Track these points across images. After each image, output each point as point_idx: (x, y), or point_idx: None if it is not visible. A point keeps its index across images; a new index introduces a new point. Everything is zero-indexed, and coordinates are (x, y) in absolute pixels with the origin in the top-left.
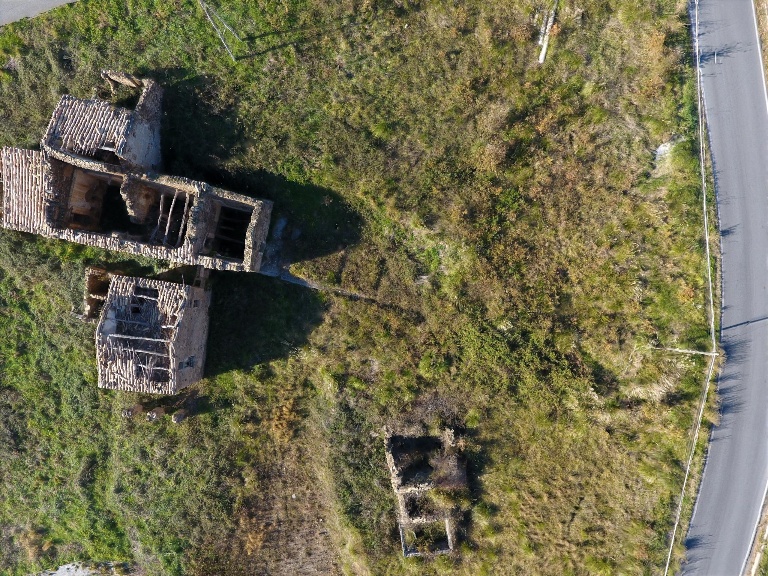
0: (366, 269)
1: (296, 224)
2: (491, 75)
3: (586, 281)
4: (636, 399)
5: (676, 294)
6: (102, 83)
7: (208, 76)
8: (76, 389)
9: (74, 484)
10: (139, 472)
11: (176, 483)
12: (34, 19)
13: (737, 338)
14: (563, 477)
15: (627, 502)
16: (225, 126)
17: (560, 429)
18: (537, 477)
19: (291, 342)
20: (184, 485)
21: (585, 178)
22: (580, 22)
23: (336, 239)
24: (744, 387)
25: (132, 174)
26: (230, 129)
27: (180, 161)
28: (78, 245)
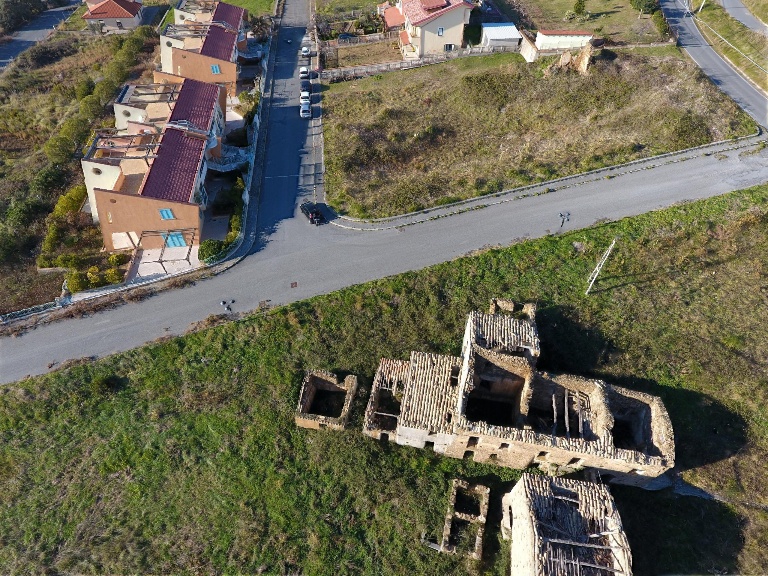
0: (765, 477)
1: None
2: None
3: None
4: None
5: None
6: None
7: (567, 305)
8: None
9: None
10: None
11: None
12: (418, 271)
13: None
14: None
15: None
16: (592, 339)
17: None
18: None
19: None
20: None
21: None
22: None
23: (719, 444)
24: None
25: (536, 372)
26: (598, 342)
27: (557, 367)
28: (433, 458)
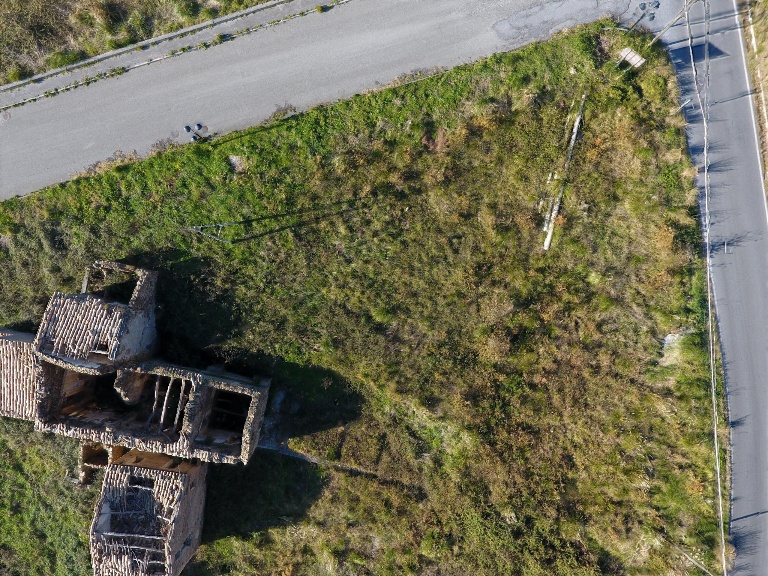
0: (366, 444)
1: (295, 398)
2: (494, 262)
3: (592, 467)
4: None
5: (684, 485)
6: None
7: (204, 259)
8: (71, 550)
9: None
10: None
11: None
12: (25, 198)
13: (747, 529)
14: None
15: None
16: (221, 310)
17: None
18: None
19: (290, 517)
20: None
21: (591, 363)
22: (586, 215)
23: (336, 414)
24: None
25: (126, 369)
26: (226, 313)
27: (175, 344)
28: None
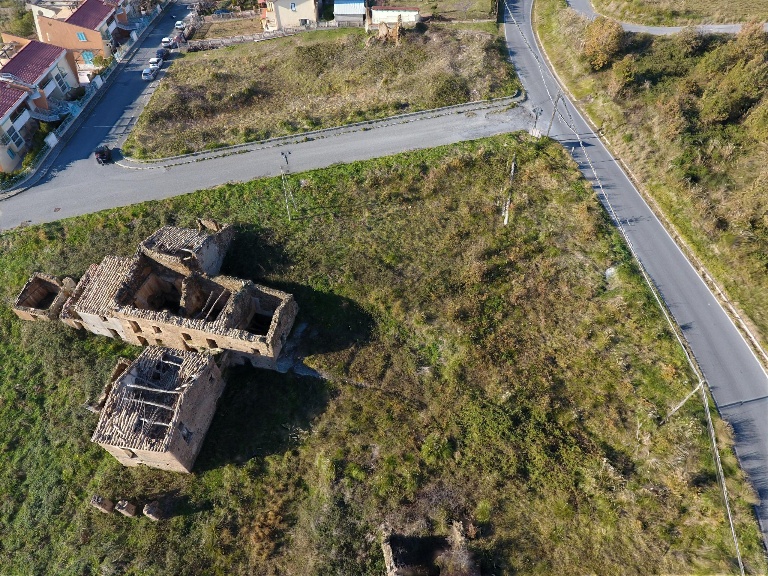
0: (373, 363)
1: (315, 327)
2: (471, 230)
3: (574, 367)
4: (656, 474)
5: (660, 375)
6: None
7: (269, 228)
8: (47, 488)
9: None
10: None
11: None
12: (161, 200)
13: (737, 417)
14: None
15: None
16: (274, 254)
17: (585, 523)
18: None
19: None
20: None
21: (554, 291)
22: (528, 202)
23: (348, 338)
24: None
25: (196, 272)
26: (277, 256)
27: (233, 274)
28: (120, 345)
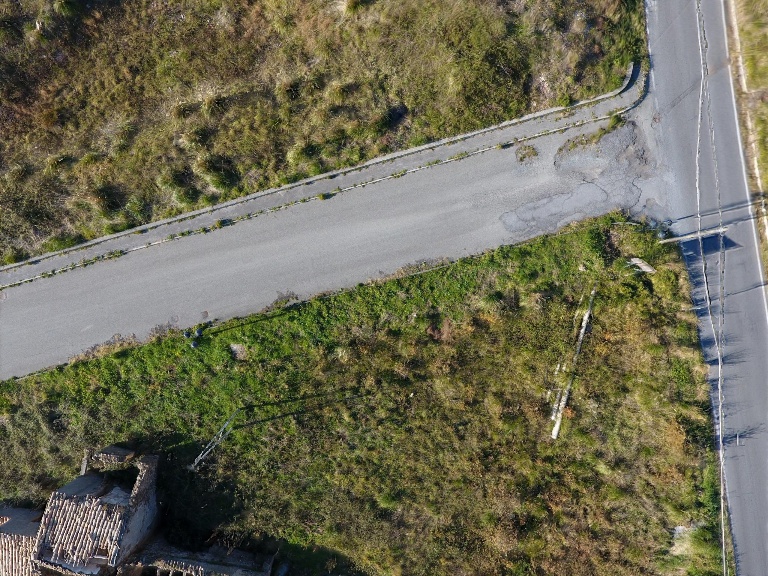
0: None
1: (298, 572)
2: (501, 451)
3: None
4: None
5: None
6: (94, 445)
7: (205, 444)
8: None
9: None
10: None
11: None
12: (22, 381)
13: None
14: None
15: None
16: (223, 495)
17: None
18: None
19: None
20: None
21: (600, 549)
22: None
23: None
24: None
25: (126, 565)
26: (228, 498)
27: (177, 528)
28: None
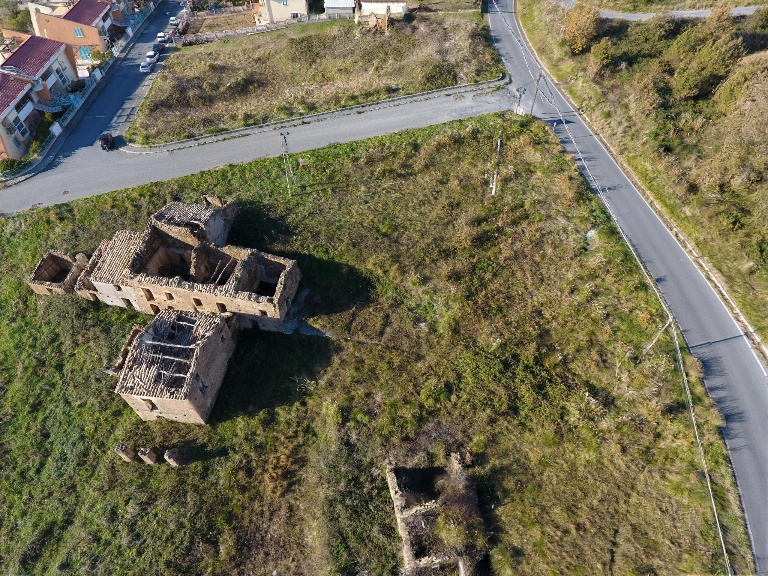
0: (373, 321)
1: (318, 291)
2: (461, 200)
3: (559, 318)
4: (633, 404)
5: (637, 321)
6: None
7: (271, 203)
8: (71, 444)
9: (12, 564)
10: (99, 540)
11: (138, 553)
12: (166, 181)
13: (707, 355)
14: (587, 504)
15: (669, 531)
16: (277, 227)
17: (570, 450)
18: (558, 506)
19: None
20: (146, 556)
21: (539, 253)
22: None
23: (349, 301)
24: (735, 397)
25: (204, 242)
26: (280, 228)
27: (239, 245)
28: (133, 314)
